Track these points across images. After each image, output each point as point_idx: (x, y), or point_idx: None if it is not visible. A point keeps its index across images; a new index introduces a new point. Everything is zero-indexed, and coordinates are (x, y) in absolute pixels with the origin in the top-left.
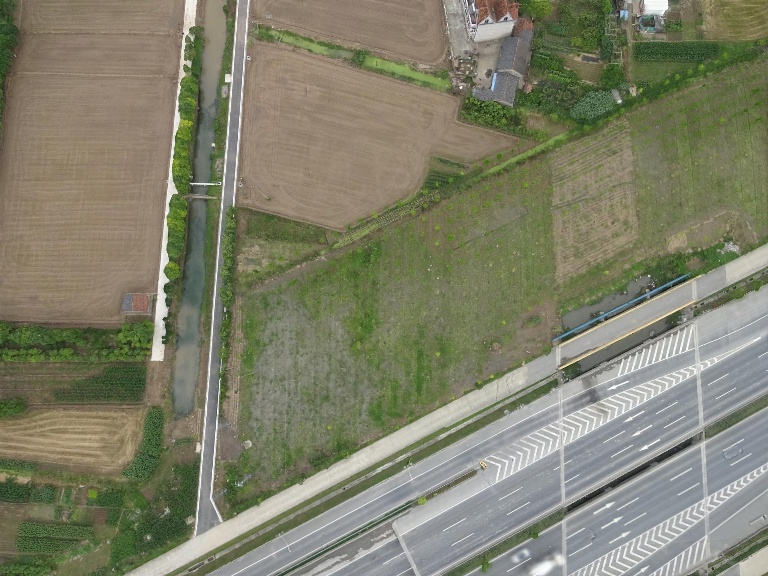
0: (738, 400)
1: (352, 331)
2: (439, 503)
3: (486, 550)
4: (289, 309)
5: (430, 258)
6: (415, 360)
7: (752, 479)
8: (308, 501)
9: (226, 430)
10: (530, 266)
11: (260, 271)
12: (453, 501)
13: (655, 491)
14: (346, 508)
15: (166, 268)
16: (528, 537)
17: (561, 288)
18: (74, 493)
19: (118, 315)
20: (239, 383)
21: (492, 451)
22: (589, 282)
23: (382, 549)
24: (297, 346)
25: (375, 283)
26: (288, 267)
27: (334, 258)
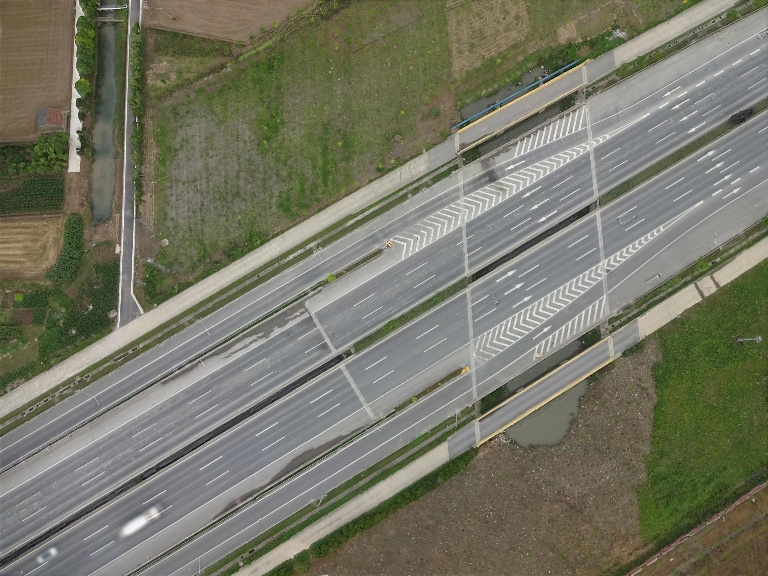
0: (630, 171)
1: (259, 132)
2: (349, 281)
3: (395, 319)
4: (198, 116)
5: (331, 62)
6: (320, 154)
7: (646, 242)
8: (225, 289)
9: (143, 231)
10: (427, 63)
11: (168, 84)
12: (362, 279)
13: (554, 258)
14: (261, 292)
15: (76, 82)
16: (434, 305)
17: (458, 81)
18: (1, 298)
19: (34, 133)
20: (154, 188)
21: (397, 232)
22: (484, 75)
23: (296, 326)
24: (207, 149)
25: (279, 87)
26: (195, 78)
27: (239, 68)
